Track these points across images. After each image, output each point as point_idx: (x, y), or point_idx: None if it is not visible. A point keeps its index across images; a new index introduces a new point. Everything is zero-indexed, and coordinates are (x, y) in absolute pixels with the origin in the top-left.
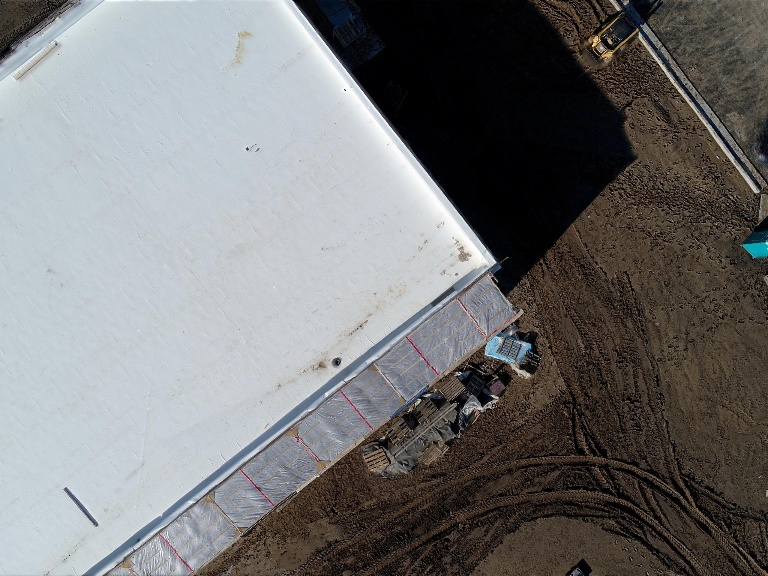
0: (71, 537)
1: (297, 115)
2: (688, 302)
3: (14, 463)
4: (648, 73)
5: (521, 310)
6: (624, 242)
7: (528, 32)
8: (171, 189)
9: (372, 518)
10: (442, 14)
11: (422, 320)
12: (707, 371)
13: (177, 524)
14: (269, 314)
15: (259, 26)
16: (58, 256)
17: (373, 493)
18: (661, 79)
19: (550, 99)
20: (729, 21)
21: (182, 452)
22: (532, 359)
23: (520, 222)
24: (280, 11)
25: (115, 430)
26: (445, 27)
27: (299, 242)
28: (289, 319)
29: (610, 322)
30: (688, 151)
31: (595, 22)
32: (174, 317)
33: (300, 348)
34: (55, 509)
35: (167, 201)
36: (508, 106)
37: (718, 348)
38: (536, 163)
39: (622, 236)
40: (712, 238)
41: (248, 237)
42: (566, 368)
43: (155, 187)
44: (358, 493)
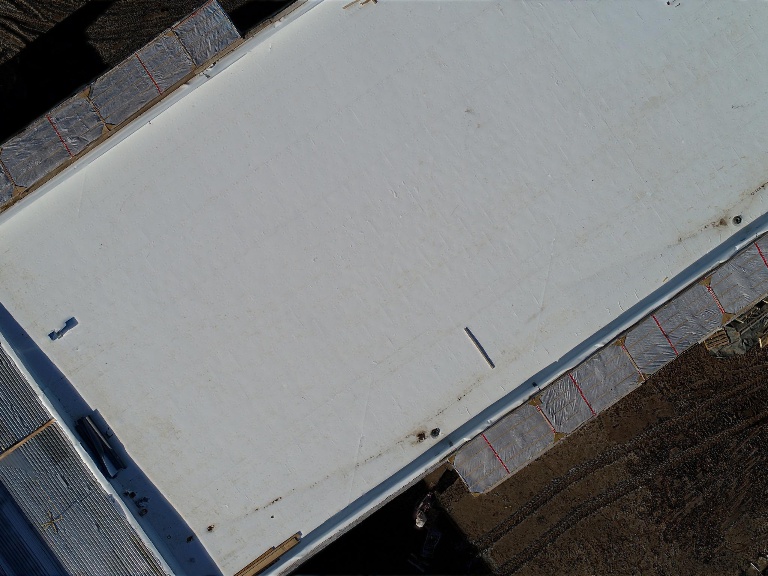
0: (467, 377)
1: None
2: None
3: (418, 300)
4: None
5: None
6: None
7: None
8: (592, 38)
9: (703, 397)
10: None
11: None
12: None
13: (587, 365)
14: (676, 168)
15: None
16: (478, 97)
17: (706, 372)
18: None
19: None
20: None
21: (582, 300)
22: None
23: None
24: None
25: (519, 273)
26: None
27: (711, 99)
28: (695, 174)
29: None
30: None
31: None
32: (584, 165)
33: (703, 204)
34: (454, 348)
35: (587, 50)
36: None
37: None
38: None
39: None
40: None
41: (662, 91)
42: None
43: (577, 35)
44: (691, 371)
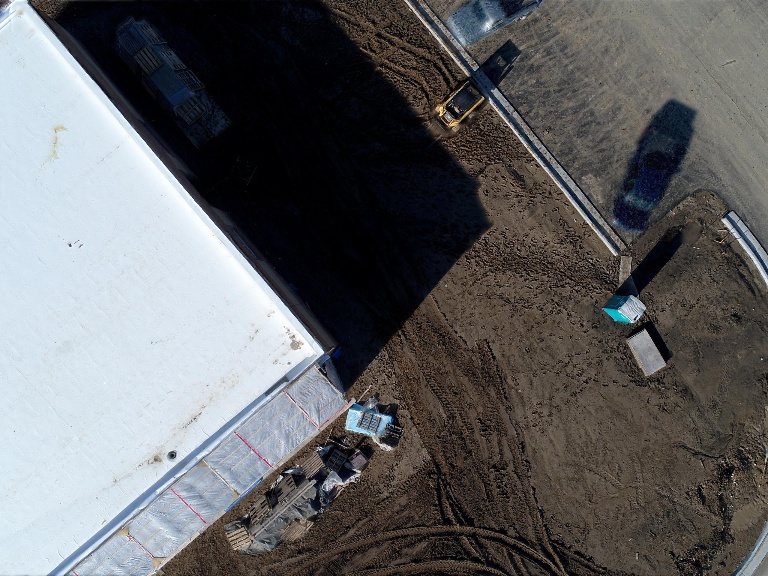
0: None
1: (119, 209)
2: (551, 367)
3: None
4: (501, 138)
5: (353, 399)
6: (483, 310)
7: (376, 102)
8: None
9: None
10: (288, 87)
11: (252, 413)
12: (573, 436)
13: None
14: (101, 410)
15: (76, 121)
16: None
17: (239, 571)
18: (515, 144)
19: (401, 169)
20: (582, 82)
21: (19, 552)
22: (393, 431)
23: (376, 294)
24: (96, 105)
25: None
26: (292, 100)
27: (128, 337)
28: (121, 414)
29: (472, 391)
30: (545, 216)
31: (445, 89)
32: (4, 417)
33: (134, 443)
34: None
35: None
36: (359, 178)
37: (583, 412)
38: (390, 234)
39: (481, 304)
40: (572, 302)
41: (75, 334)
42: (429, 439)
43: None
44: (224, 572)
